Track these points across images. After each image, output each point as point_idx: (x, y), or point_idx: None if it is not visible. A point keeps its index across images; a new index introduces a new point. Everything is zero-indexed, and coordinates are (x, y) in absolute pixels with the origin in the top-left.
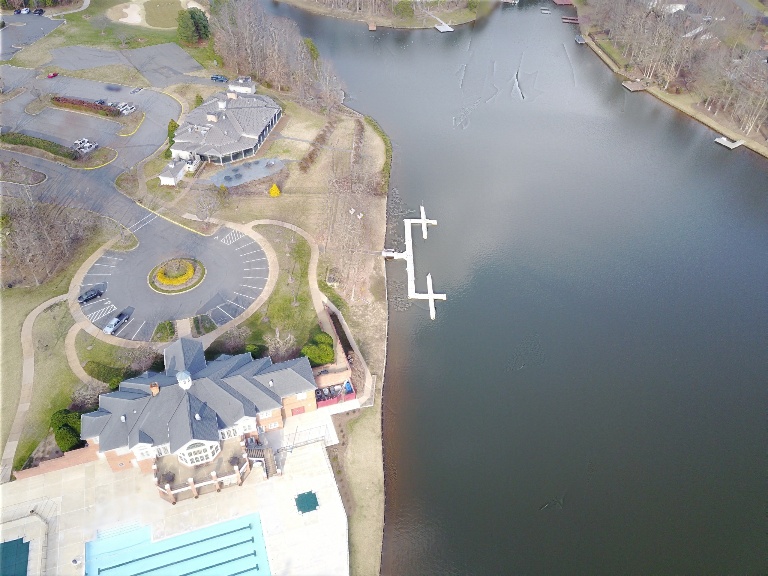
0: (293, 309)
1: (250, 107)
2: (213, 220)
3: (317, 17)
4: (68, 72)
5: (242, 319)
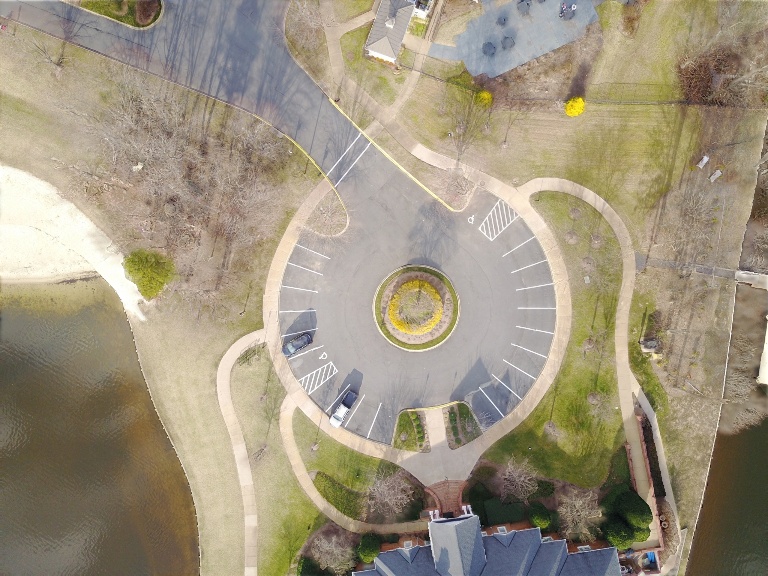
0: (590, 411)
1: None
2: (464, 170)
3: None
4: None
5: (516, 421)
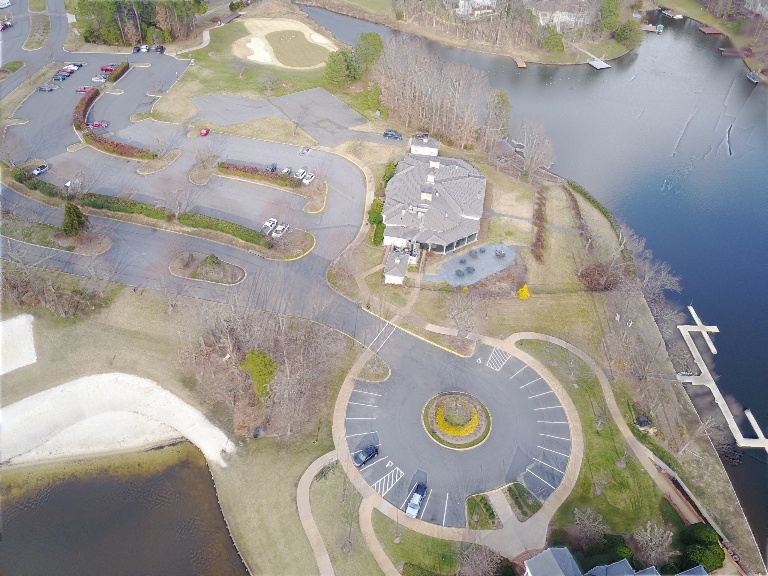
0: (622, 473)
1: (456, 178)
2: None
3: (453, 51)
4: (221, 128)
5: (567, 490)
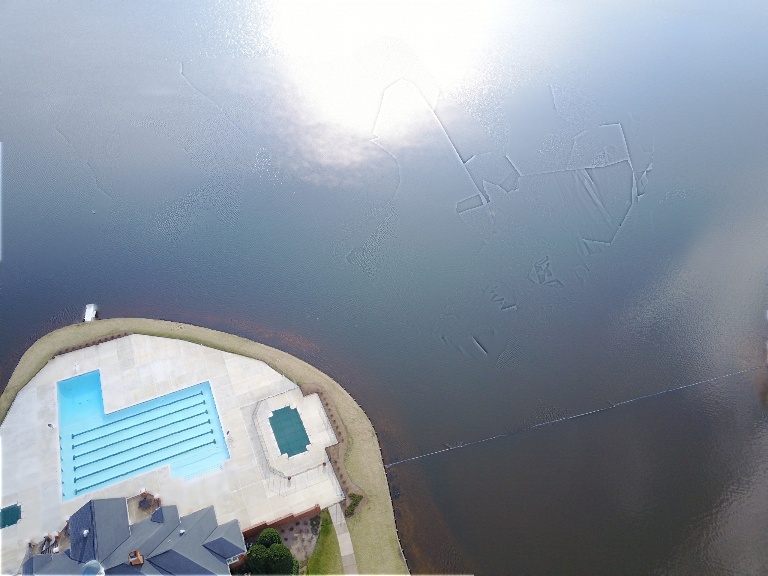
0: None
1: None
2: None
3: None
4: None
5: None
